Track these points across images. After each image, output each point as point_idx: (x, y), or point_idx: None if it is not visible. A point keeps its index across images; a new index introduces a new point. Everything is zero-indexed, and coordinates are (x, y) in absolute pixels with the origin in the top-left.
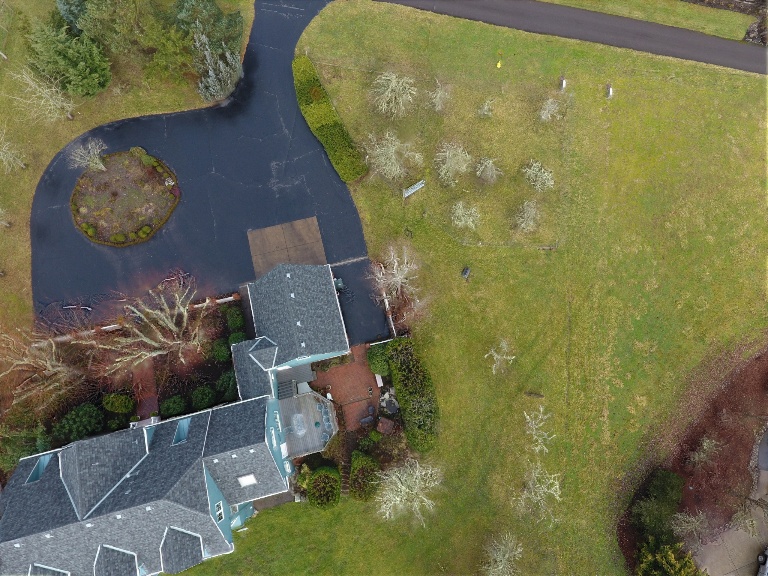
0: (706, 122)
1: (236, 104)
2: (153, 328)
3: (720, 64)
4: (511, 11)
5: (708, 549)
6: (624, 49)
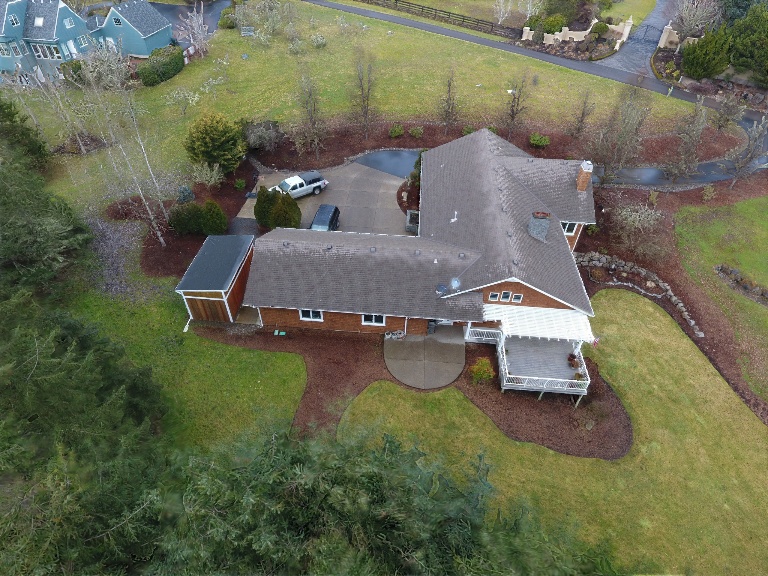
0: (442, 52)
1: (197, 7)
2: (68, 1)
3: (469, 41)
4: (361, 11)
5: (276, 175)
6: (413, 27)
